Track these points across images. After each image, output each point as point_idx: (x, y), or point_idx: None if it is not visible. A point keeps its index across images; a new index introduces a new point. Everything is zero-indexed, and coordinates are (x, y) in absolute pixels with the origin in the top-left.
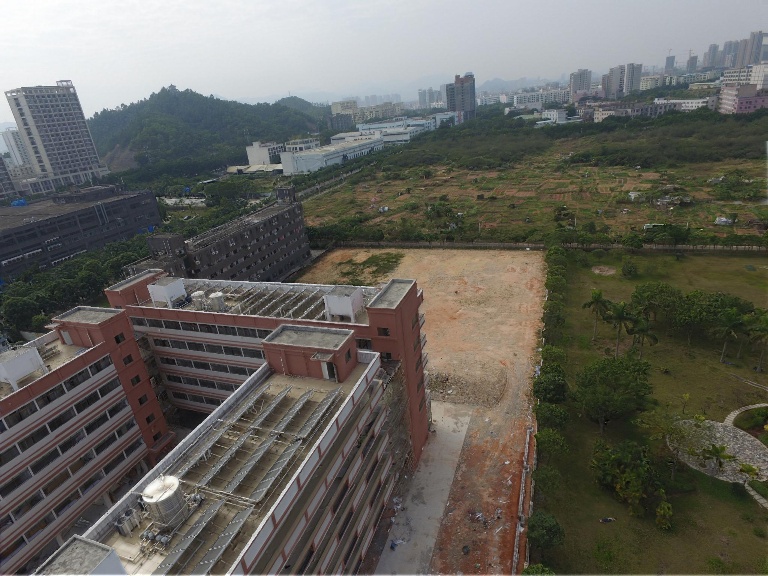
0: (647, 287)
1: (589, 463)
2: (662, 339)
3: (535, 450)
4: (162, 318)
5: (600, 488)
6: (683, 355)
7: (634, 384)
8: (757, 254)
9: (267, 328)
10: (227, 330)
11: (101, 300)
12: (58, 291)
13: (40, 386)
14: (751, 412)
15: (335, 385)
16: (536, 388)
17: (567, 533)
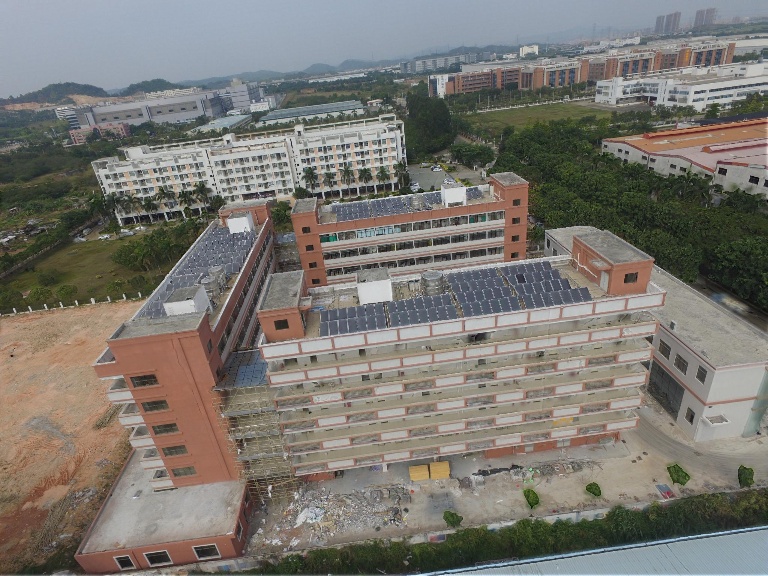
0: (124, 250)
1: None
2: (160, 268)
3: None
4: None
5: None
6: None
7: None
8: (49, 253)
9: None
10: None
11: None
12: None
13: None
14: None
15: None
16: None
17: None
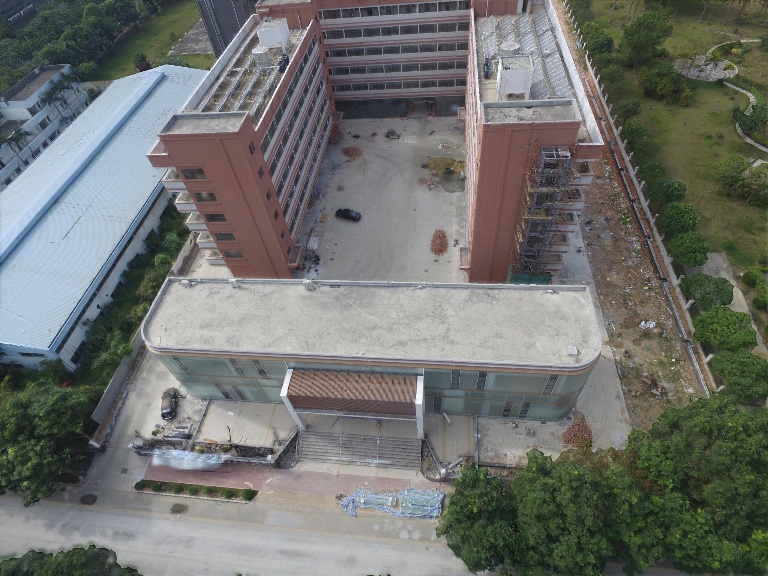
0: None
1: (632, 87)
2: None
3: (598, 85)
4: (322, 8)
5: (644, 96)
6: (673, 23)
7: (666, 27)
8: None
9: (429, 1)
10: (388, 10)
11: (116, 51)
12: (81, 39)
13: (302, 48)
14: (723, 46)
15: (529, 15)
16: (593, 46)
17: (632, 118)
